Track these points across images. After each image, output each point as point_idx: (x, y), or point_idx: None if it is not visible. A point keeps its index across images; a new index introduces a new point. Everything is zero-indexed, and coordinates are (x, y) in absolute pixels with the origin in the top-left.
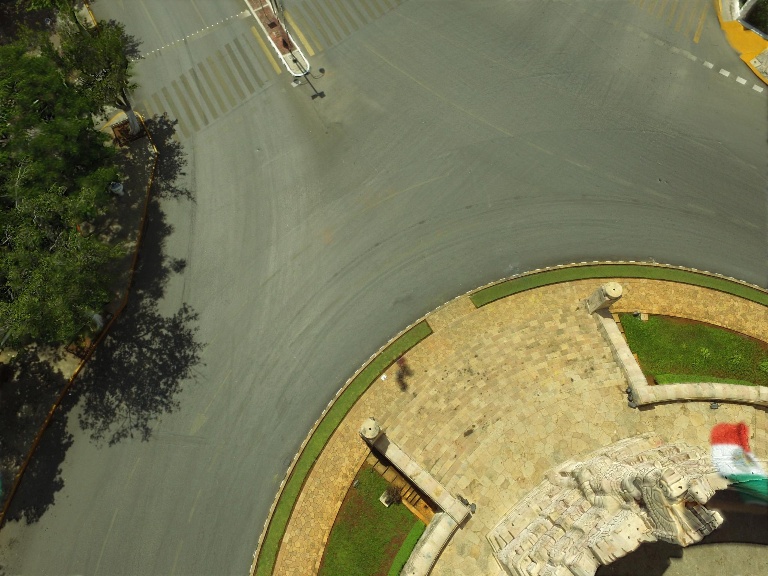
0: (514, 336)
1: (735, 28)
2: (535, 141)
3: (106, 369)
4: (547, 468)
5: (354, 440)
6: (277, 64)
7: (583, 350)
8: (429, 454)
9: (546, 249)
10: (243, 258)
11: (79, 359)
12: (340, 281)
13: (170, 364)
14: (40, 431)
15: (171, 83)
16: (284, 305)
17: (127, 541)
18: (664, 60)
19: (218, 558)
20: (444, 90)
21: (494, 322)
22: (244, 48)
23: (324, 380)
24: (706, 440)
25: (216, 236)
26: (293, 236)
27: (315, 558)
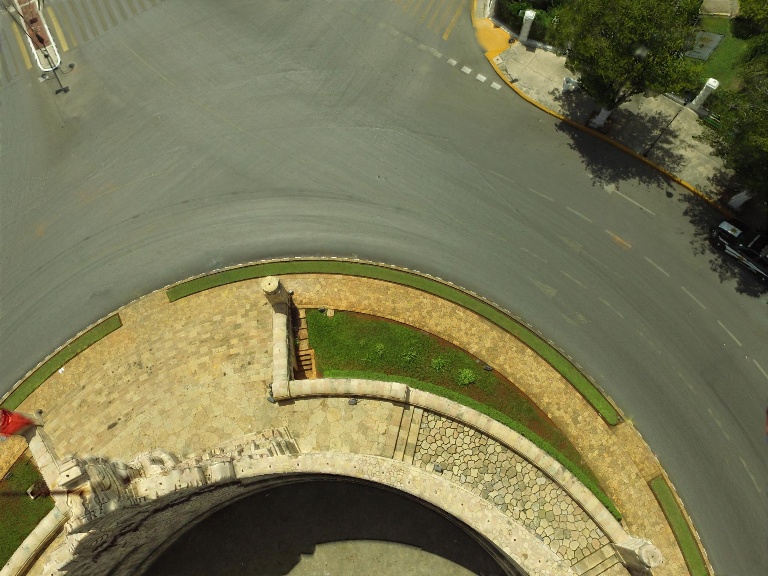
0: (193, 330)
1: (486, 26)
2: (265, 137)
3: None
4: None
5: None
6: (29, 59)
7: (249, 345)
8: (71, 446)
9: (252, 244)
10: None
11: None
12: (43, 274)
13: None
14: None
15: None
16: None
17: None
18: (409, 57)
19: None
20: (187, 86)
21: (182, 316)
22: (1, 43)
23: (6, 372)
24: (337, 436)
25: None
26: (7, 229)
27: None
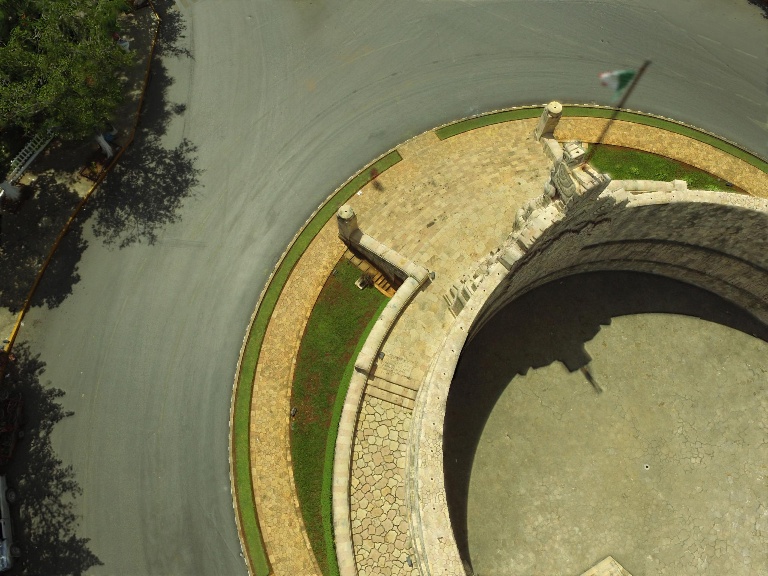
0: (472, 158)
1: None
2: (495, 10)
3: (116, 190)
4: None
5: (333, 241)
6: None
7: (530, 164)
8: (397, 242)
9: (502, 95)
10: (237, 103)
11: (92, 182)
12: (322, 120)
13: (173, 186)
14: (58, 237)
15: None
16: (273, 139)
17: (136, 321)
18: None
19: (216, 332)
20: None
21: (456, 150)
22: None
23: (308, 197)
24: None
25: (212, 86)
26: (281, 85)
27: (299, 329)
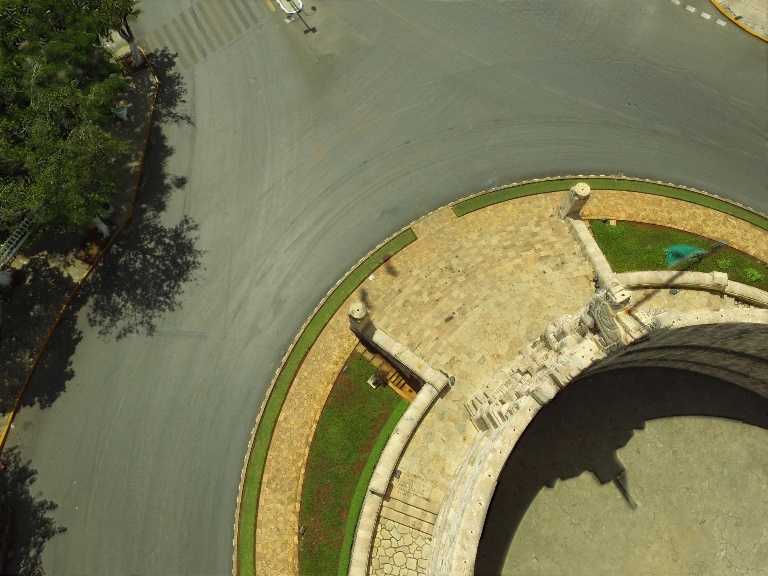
0: (492, 239)
1: None
2: (513, 70)
3: (112, 274)
4: (520, 346)
5: (344, 332)
6: (271, 3)
7: (555, 248)
8: (413, 338)
9: (523, 165)
10: (240, 175)
11: (87, 265)
12: (331, 195)
13: (172, 269)
14: (51, 328)
15: (171, 20)
16: (279, 216)
17: (134, 422)
18: None
19: (218, 436)
20: (428, 25)
21: (474, 229)
22: None
23: (316, 281)
24: None
25: (215, 156)
26: (287, 155)
27: (308, 433)
